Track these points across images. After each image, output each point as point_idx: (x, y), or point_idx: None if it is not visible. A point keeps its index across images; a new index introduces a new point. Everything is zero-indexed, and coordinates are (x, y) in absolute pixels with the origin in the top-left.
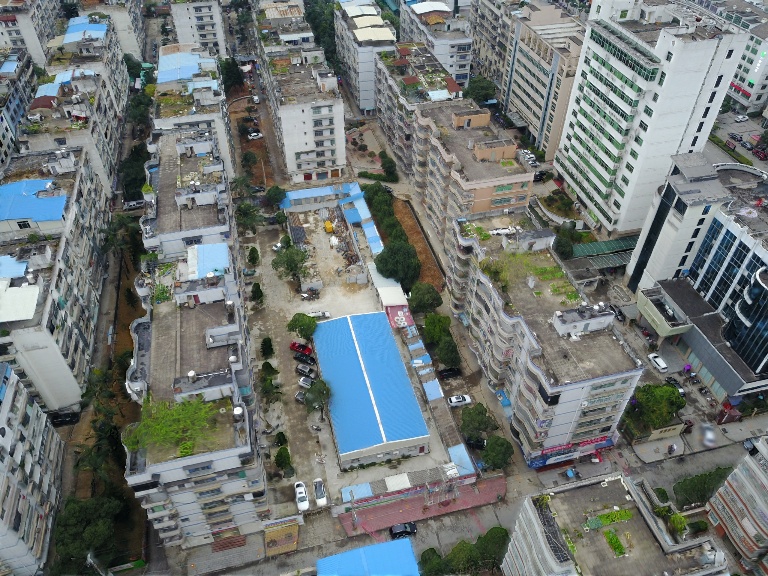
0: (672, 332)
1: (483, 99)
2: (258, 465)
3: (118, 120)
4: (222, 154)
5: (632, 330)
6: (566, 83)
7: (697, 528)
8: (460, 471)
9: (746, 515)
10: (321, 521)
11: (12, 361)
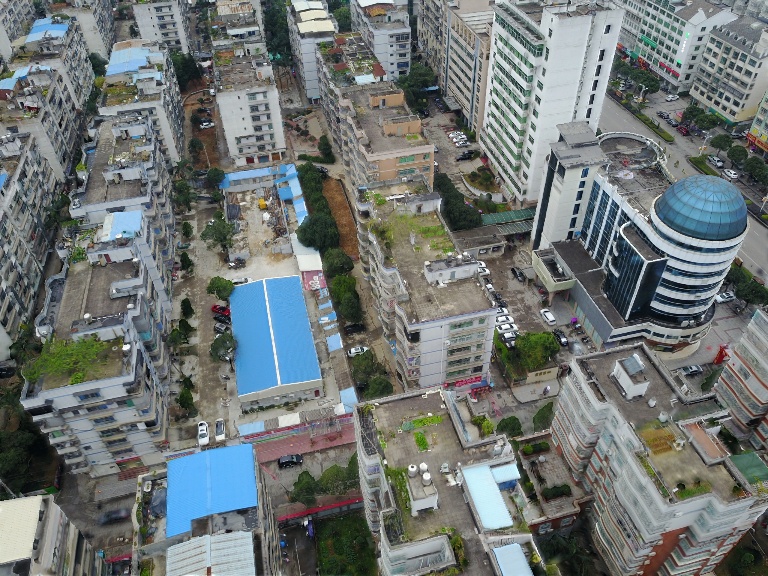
0: (558, 287)
1: (422, 85)
2: (145, 395)
3: (79, 113)
4: (166, 140)
5: (530, 289)
6: (487, 66)
7: (539, 448)
8: (347, 410)
9: (571, 431)
10: None
11: None
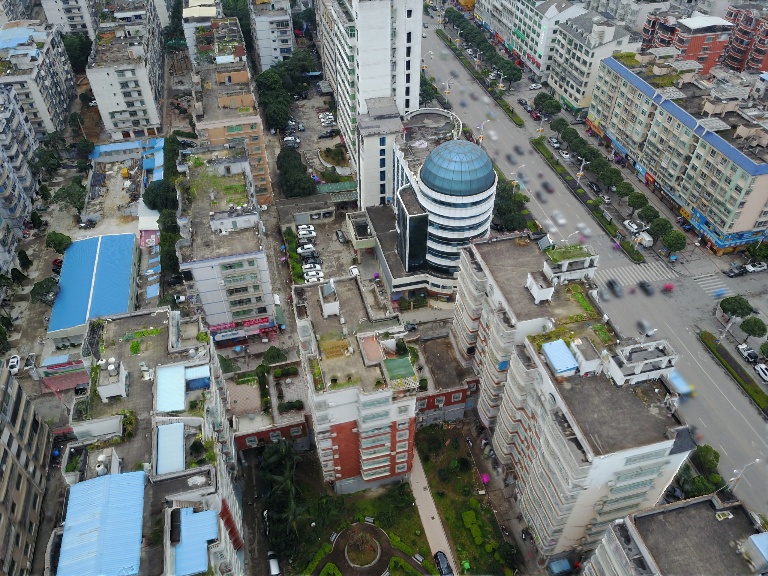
0: (361, 245)
1: (301, 70)
2: None
3: None
4: (40, 112)
5: (348, 249)
6: None
7: (286, 372)
8: None
9: None
10: (24, 383)
11: None
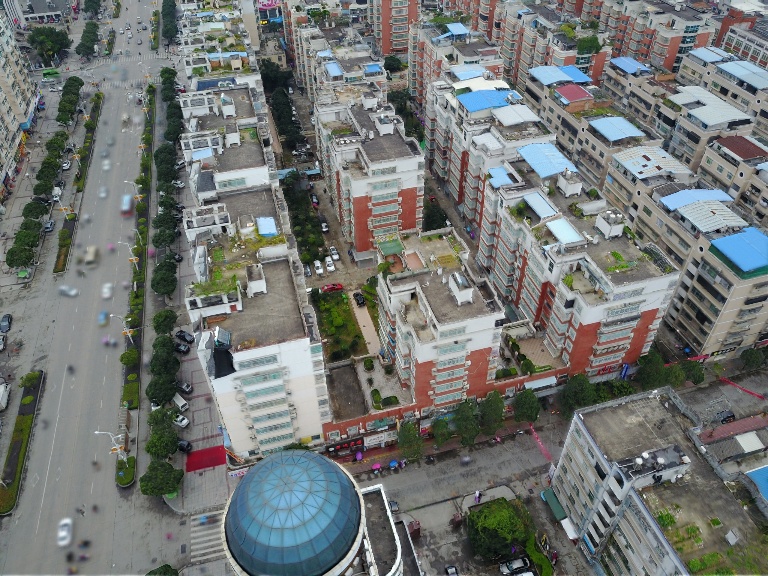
0: None
1: None
2: None
3: None
4: None
5: None
6: None
7: None
8: None
9: None
10: None
11: None
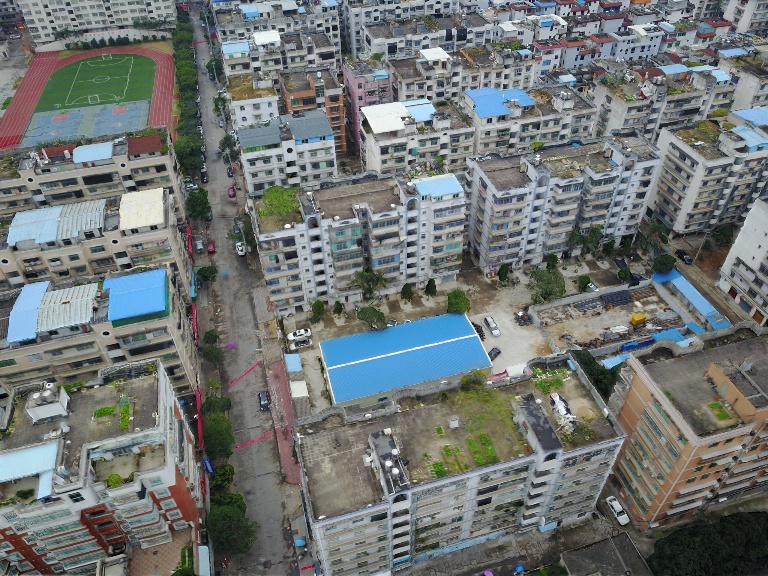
0: None
1: None
2: (264, 258)
3: None
4: (686, 200)
5: None
6: None
7: None
8: None
9: None
10: (279, 349)
11: (365, 151)
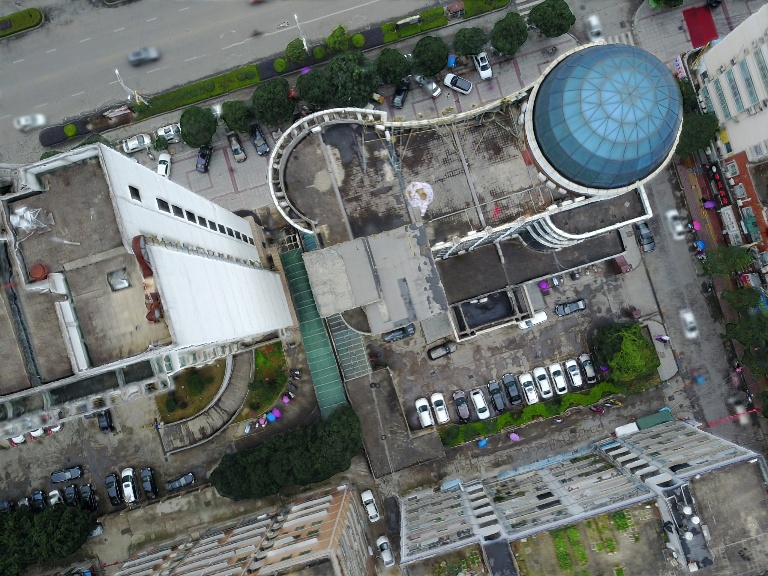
0: None
1: None
2: None
3: None
4: None
5: None
6: None
7: None
8: None
9: None
10: None
11: None
